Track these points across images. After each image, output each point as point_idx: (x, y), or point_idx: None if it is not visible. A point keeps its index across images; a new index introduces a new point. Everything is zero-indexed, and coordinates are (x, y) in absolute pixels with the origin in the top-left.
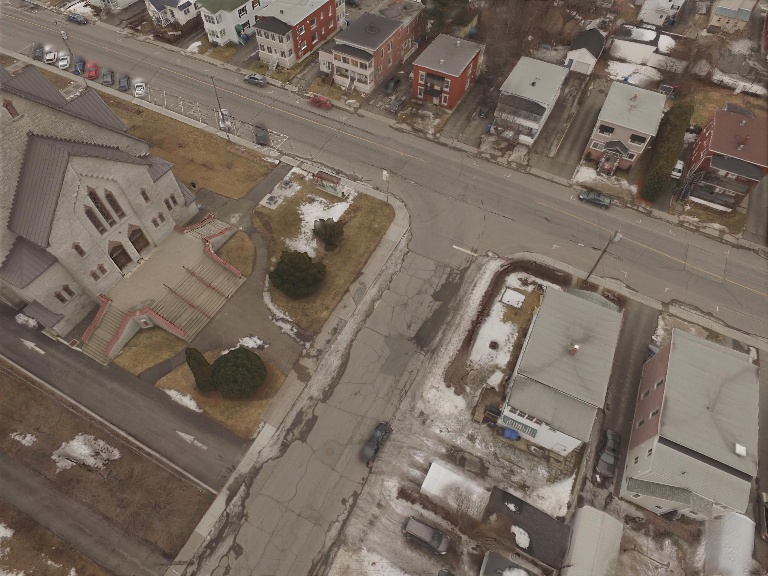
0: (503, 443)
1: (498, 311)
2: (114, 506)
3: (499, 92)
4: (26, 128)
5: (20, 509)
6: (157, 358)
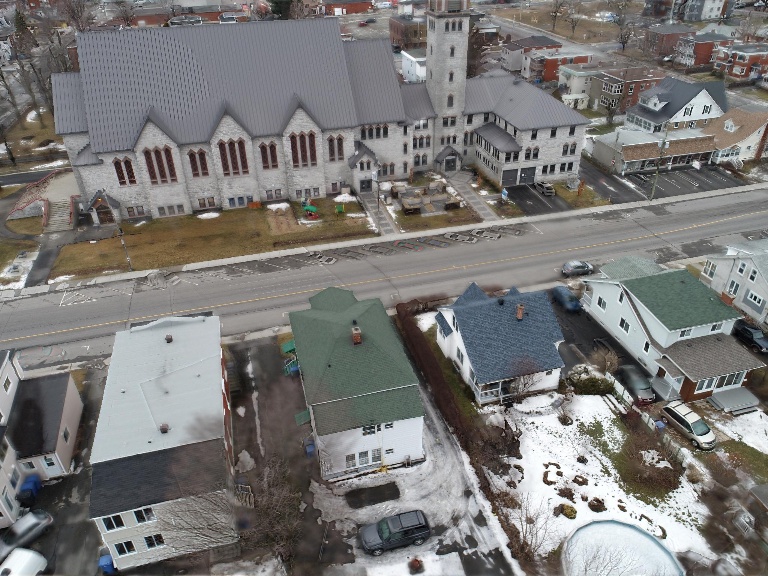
0: None
1: None
2: None
3: None
4: None
5: None
6: None
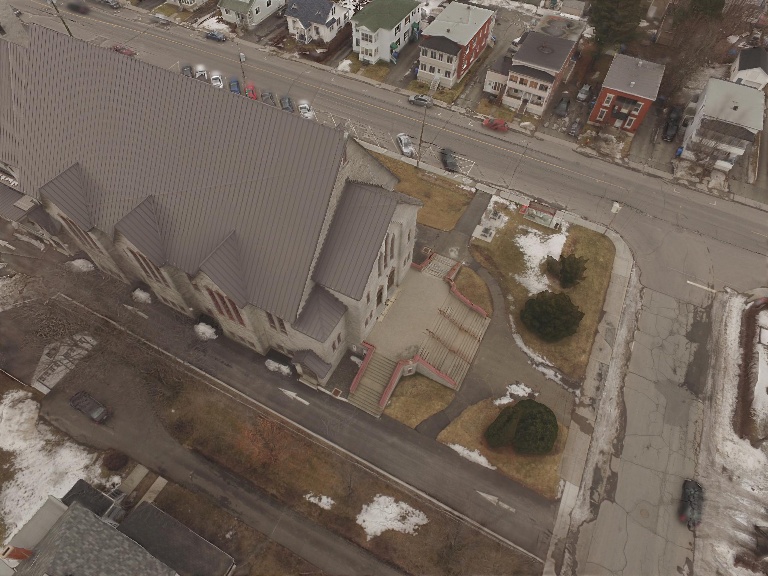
0: None
1: (761, 353)
2: None
3: (678, 114)
4: (346, 174)
5: None
6: (430, 409)
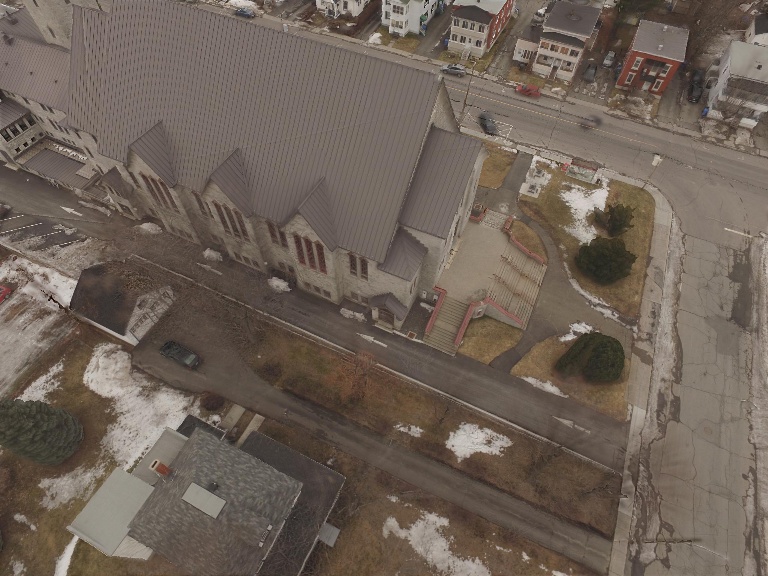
0: None
1: None
2: (531, 491)
3: (702, 77)
4: (432, 119)
5: (443, 498)
6: (501, 347)
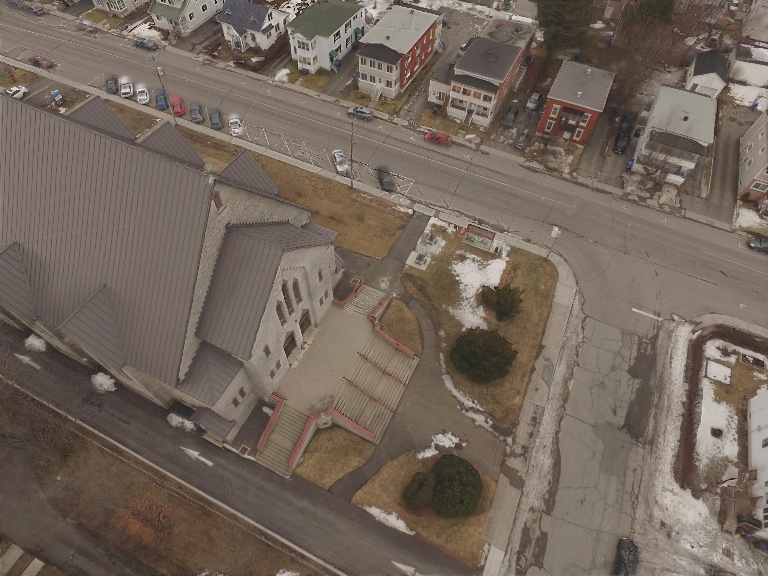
0: (765, 558)
1: (707, 389)
2: None
3: (630, 123)
4: (226, 219)
5: None
6: (346, 466)
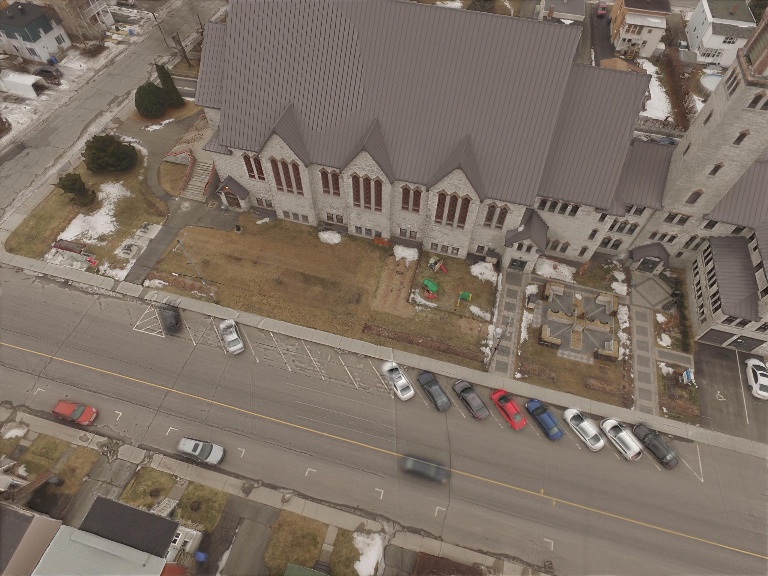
0: None
1: None
2: None
3: None
4: None
5: None
6: None
